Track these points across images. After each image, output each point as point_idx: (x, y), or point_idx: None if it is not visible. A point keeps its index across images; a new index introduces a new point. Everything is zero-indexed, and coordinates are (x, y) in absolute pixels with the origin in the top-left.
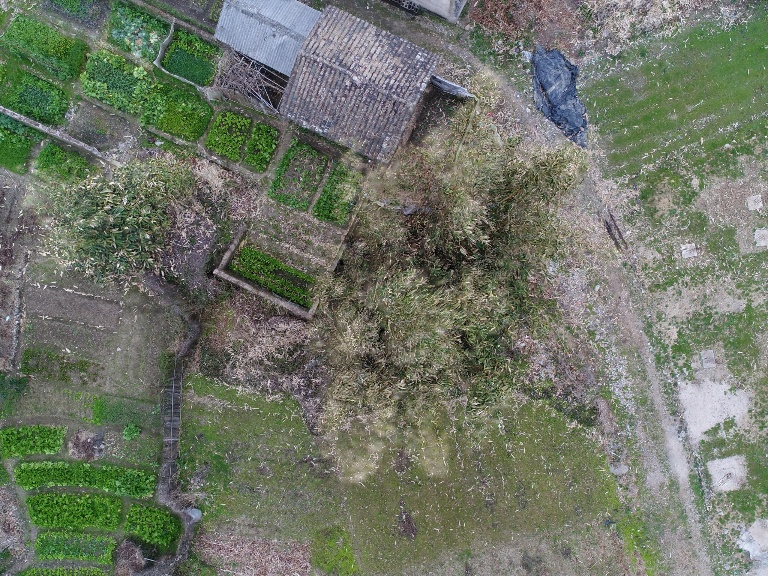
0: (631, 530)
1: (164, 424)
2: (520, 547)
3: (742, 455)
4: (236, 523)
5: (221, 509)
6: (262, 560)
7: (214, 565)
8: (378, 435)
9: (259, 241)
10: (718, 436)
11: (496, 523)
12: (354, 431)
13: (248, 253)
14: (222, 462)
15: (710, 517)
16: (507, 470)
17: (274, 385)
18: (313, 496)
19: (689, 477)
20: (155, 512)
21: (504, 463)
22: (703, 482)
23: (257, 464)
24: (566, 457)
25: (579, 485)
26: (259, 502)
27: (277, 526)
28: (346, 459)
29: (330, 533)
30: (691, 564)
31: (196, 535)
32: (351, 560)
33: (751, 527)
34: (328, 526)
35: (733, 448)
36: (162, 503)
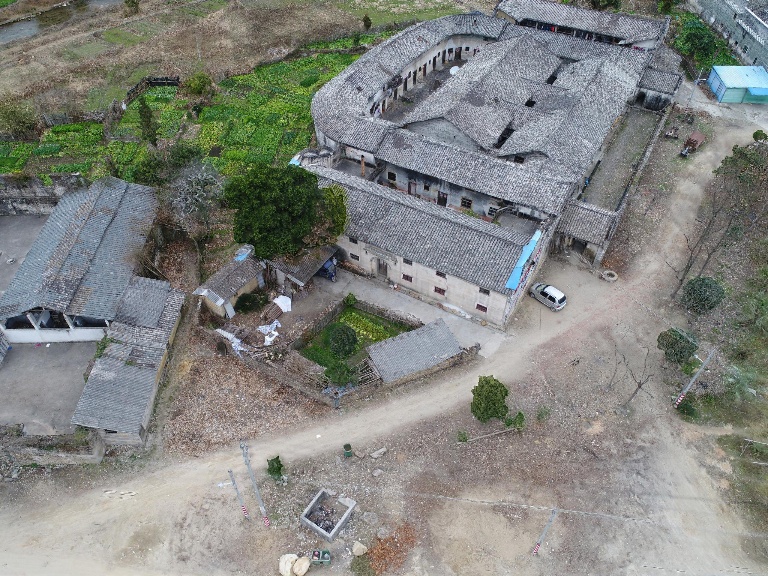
0: None
1: None
2: None
3: None
4: None
5: None
6: None
7: None
8: None
9: (563, 3)
10: None
11: None
12: None
13: (566, 1)
14: None
15: None
16: None
17: None
18: None
19: None
20: None
21: None
22: None
23: None
24: None
25: None
26: None
27: None
28: None
29: None
30: None
31: None
32: None
33: None
34: None
35: None
36: None
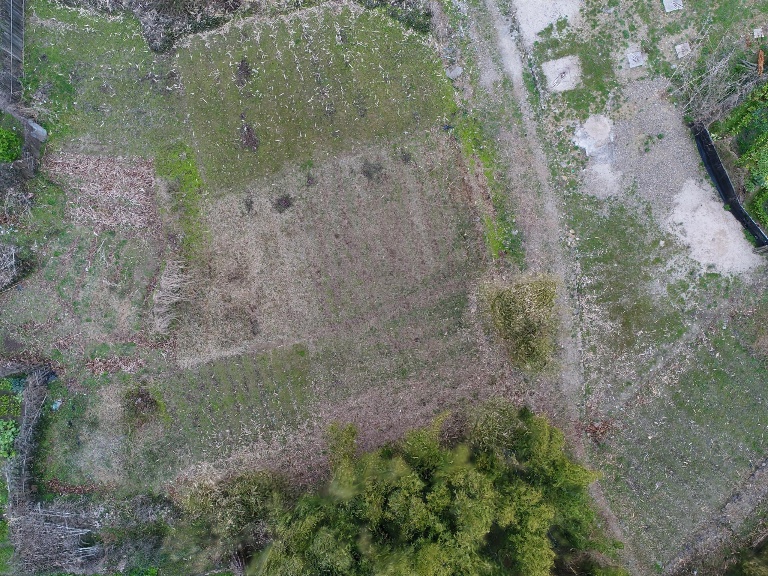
0: (469, 133)
1: (1, 33)
2: (361, 155)
3: (576, 55)
4: (81, 142)
5: (66, 129)
6: (107, 176)
7: (61, 184)
8: (218, 50)
9: None
10: (551, 37)
11: (336, 132)
12: (194, 47)
13: None
14: (65, 82)
15: (545, 115)
16: (345, 79)
17: (113, 2)
18: (156, 113)
19: (523, 75)
20: (0, 131)
21: (342, 73)
22: (538, 84)
23: (100, 83)
24: (403, 65)
25: (416, 91)
26: (103, 121)
27: (122, 144)
28: (187, 75)
29: (173, 147)
30: (527, 160)
31: (43, 156)
32: (195, 175)
33: (586, 123)
34: (172, 143)
35: (567, 48)
36: (9, 127)
